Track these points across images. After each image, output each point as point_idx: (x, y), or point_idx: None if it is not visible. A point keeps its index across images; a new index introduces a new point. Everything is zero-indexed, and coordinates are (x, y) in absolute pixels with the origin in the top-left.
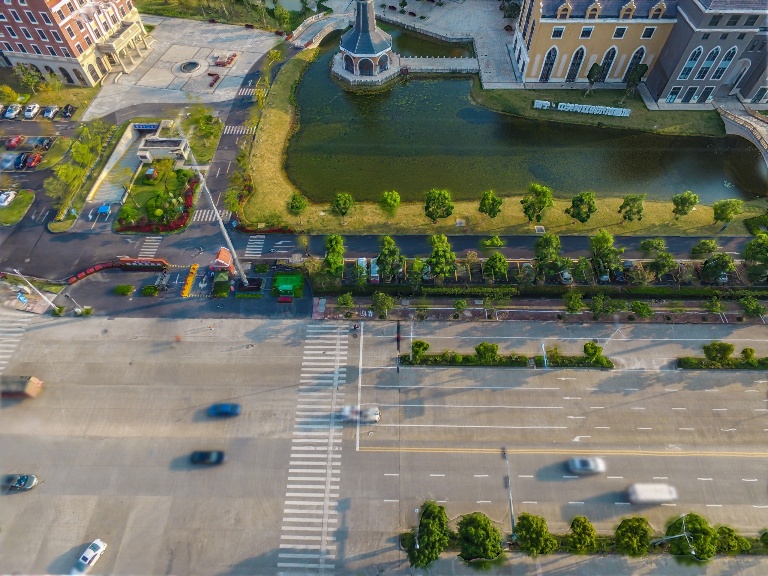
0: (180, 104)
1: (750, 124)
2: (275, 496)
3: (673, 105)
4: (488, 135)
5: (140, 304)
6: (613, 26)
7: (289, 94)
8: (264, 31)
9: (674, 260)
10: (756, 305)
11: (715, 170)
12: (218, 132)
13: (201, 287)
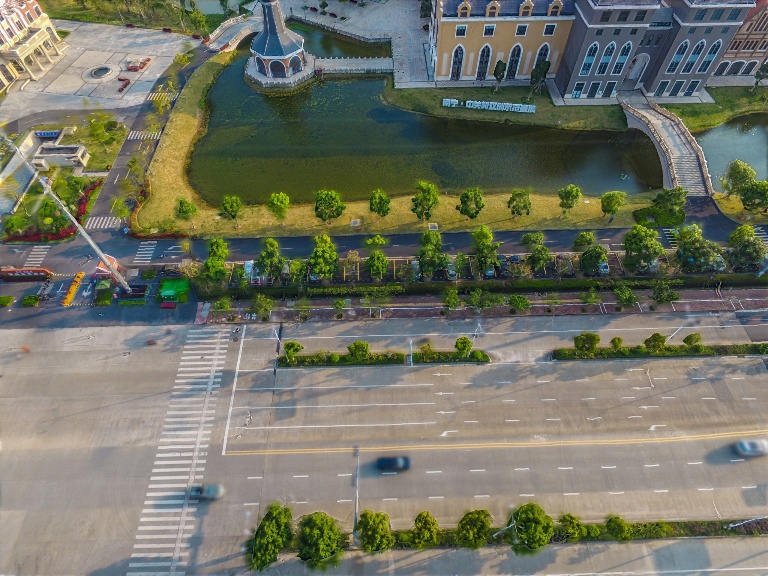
0: (86, 110)
1: (646, 117)
2: (133, 505)
3: (579, 100)
4: (395, 134)
5: (19, 315)
6: (514, 24)
7: (200, 98)
8: (182, 35)
9: (561, 253)
10: (629, 295)
11: (614, 163)
12: (121, 138)
13: (84, 295)
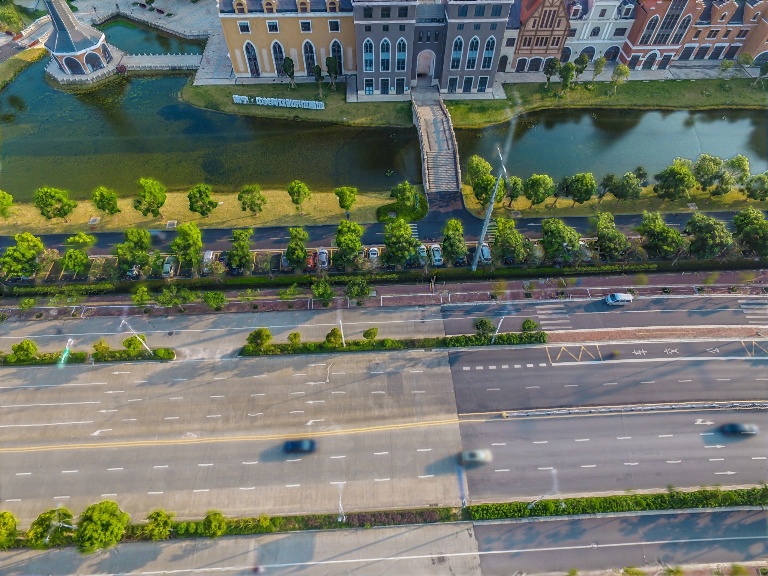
0: None
1: None
2: None
3: (372, 97)
4: (178, 131)
5: None
6: (296, 20)
7: None
8: None
9: None
10: (325, 290)
11: (386, 159)
12: None
13: None
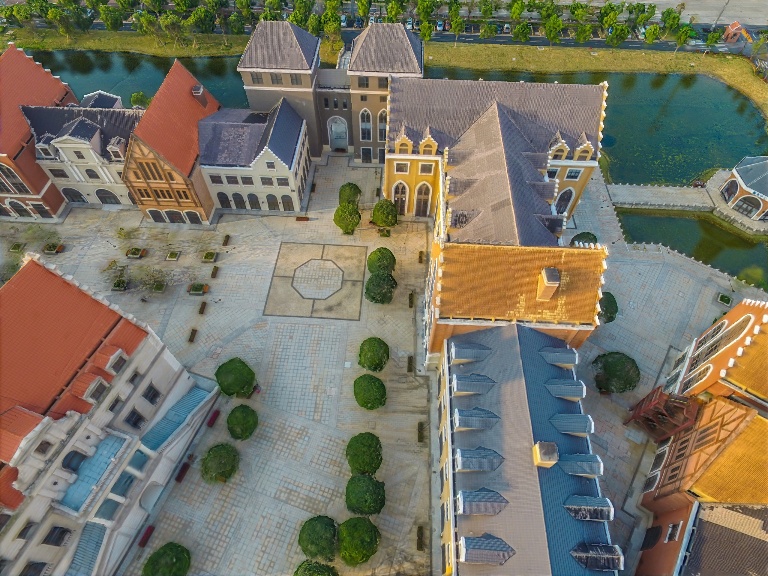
0: None
1: None
2: None
3: None
4: None
5: (763, 28)
6: None
7: None
8: None
9: None
10: None
11: None
12: None
13: None
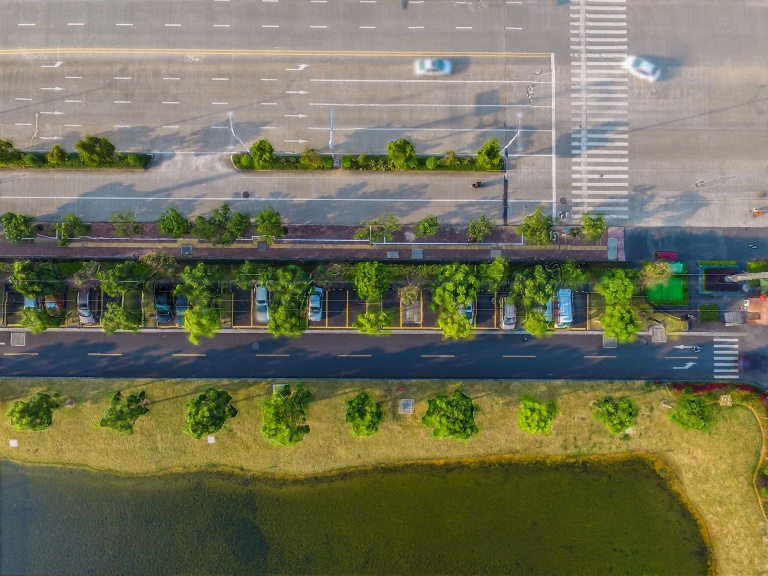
0: None
1: None
2: (637, 6)
3: None
4: None
5: None
6: None
7: None
8: None
9: (90, 329)
10: None
11: None
12: None
13: None
